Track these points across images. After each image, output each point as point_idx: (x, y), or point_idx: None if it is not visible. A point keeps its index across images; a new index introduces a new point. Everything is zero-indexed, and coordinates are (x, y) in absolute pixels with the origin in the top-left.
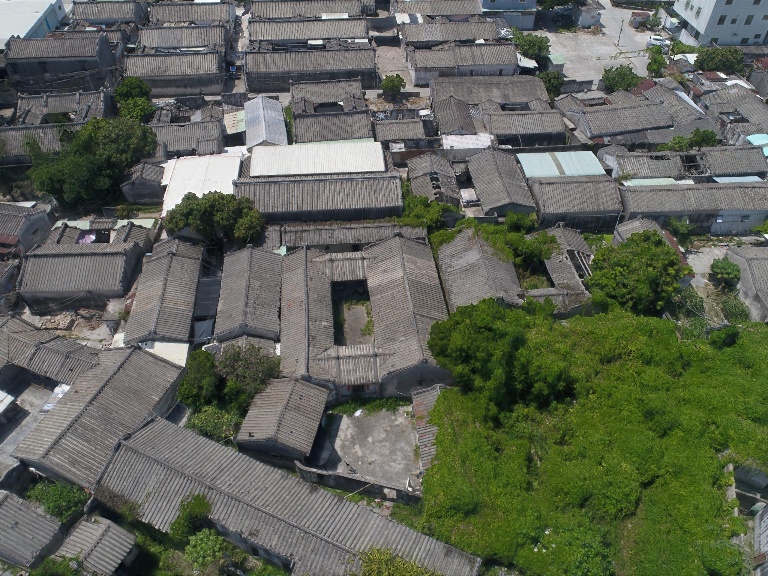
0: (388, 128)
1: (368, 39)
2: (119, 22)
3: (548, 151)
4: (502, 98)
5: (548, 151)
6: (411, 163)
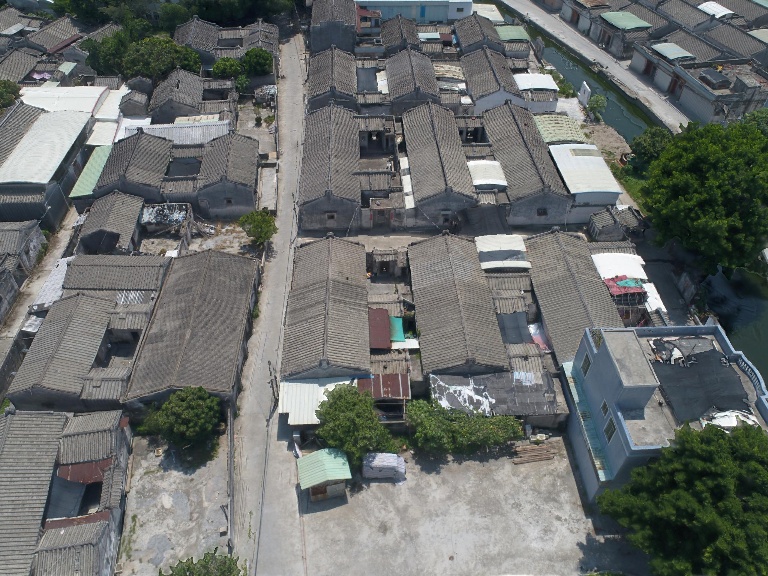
0: (107, 204)
1: (449, 219)
2: (438, 41)
3: (0, 380)
4: (157, 333)
5: (0, 380)
6: (27, 221)
